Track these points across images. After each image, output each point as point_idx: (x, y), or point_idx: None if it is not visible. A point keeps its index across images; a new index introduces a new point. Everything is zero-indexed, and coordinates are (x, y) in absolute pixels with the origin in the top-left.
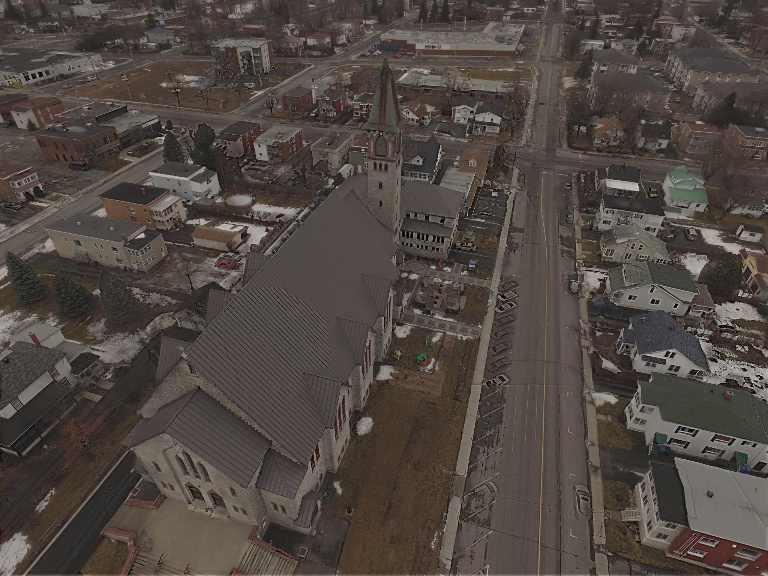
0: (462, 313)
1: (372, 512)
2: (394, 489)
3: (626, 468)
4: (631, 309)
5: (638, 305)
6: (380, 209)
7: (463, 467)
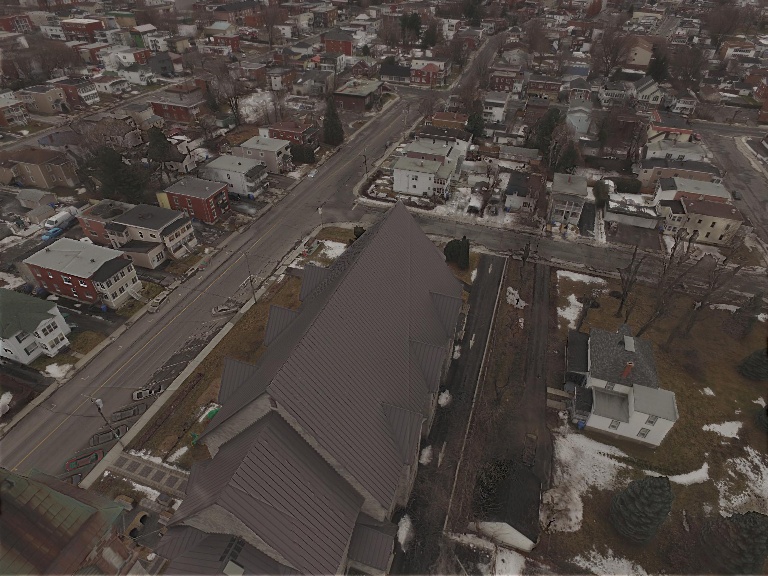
0: None
1: None
2: None
3: (105, 321)
4: None
5: None
6: None
7: (227, 327)
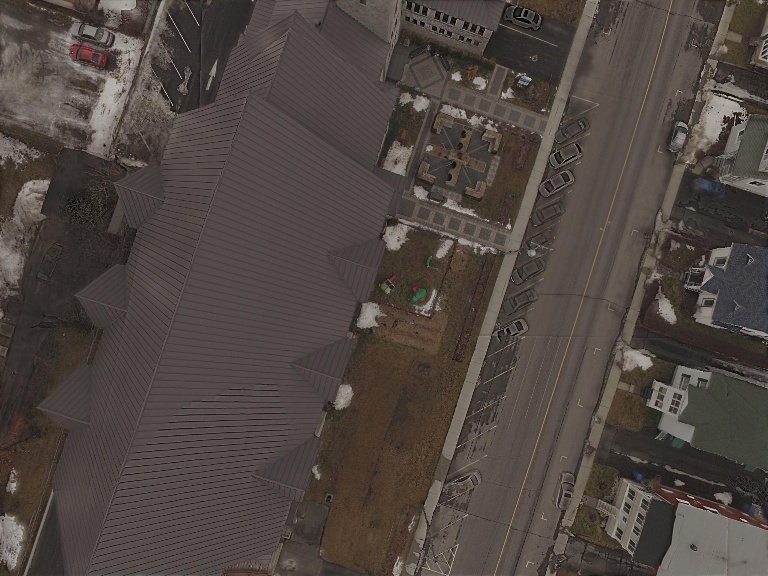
0: (488, 197)
1: (352, 498)
2: (375, 474)
3: (624, 452)
4: (743, 193)
5: (758, 190)
6: (361, 7)
7: (450, 449)
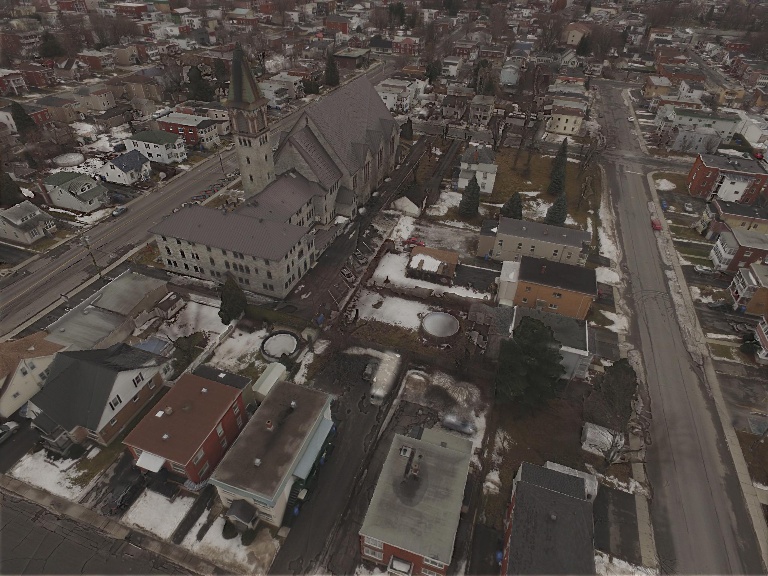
0: None
1: None
2: None
3: None
4: None
5: None
6: None
7: None
